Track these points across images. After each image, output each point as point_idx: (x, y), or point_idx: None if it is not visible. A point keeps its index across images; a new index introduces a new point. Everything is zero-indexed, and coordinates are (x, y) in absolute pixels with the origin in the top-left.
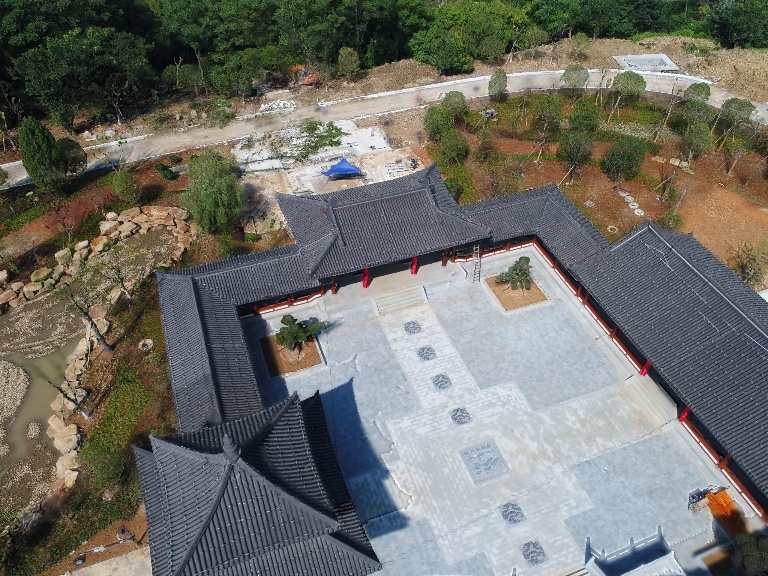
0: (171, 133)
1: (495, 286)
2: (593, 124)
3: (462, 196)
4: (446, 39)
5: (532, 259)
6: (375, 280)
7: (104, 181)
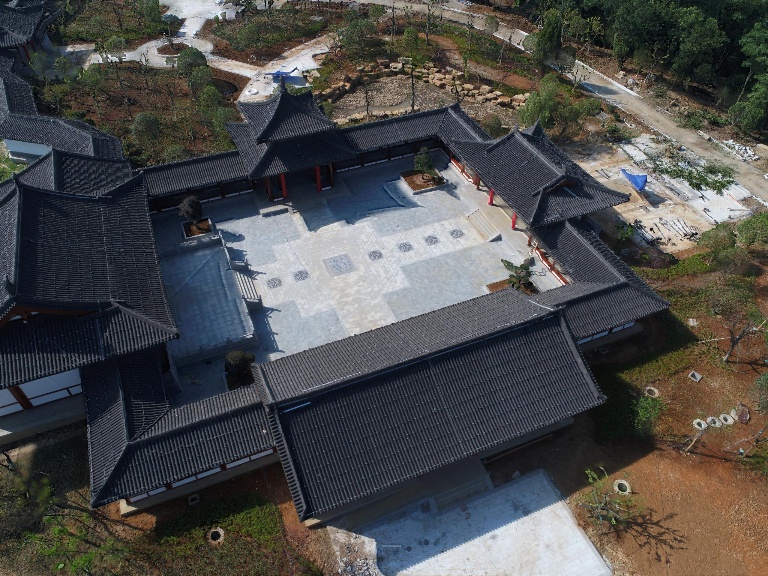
0: (651, 105)
1: (517, 281)
2: None
3: (653, 269)
4: None
5: None
6: (499, 208)
7: (565, 87)
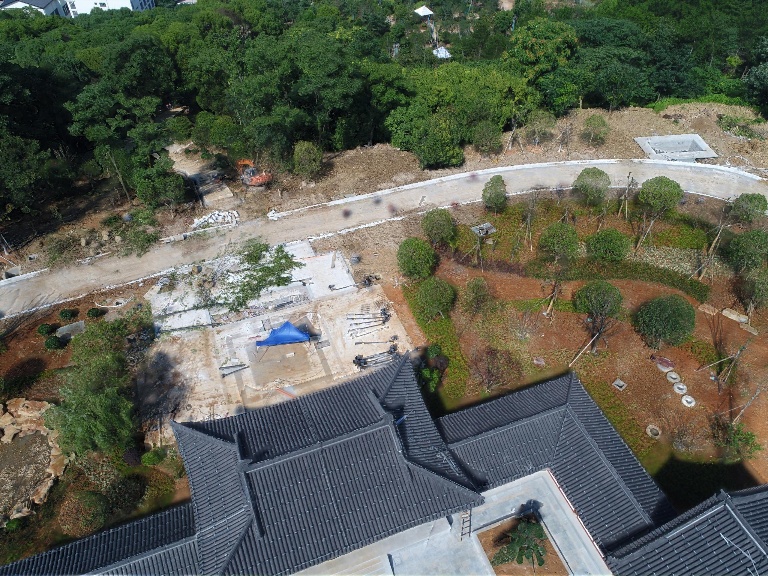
0: (72, 266)
1: (492, 549)
2: (619, 259)
3: (447, 372)
4: (429, 129)
5: (544, 490)
6: None
7: None
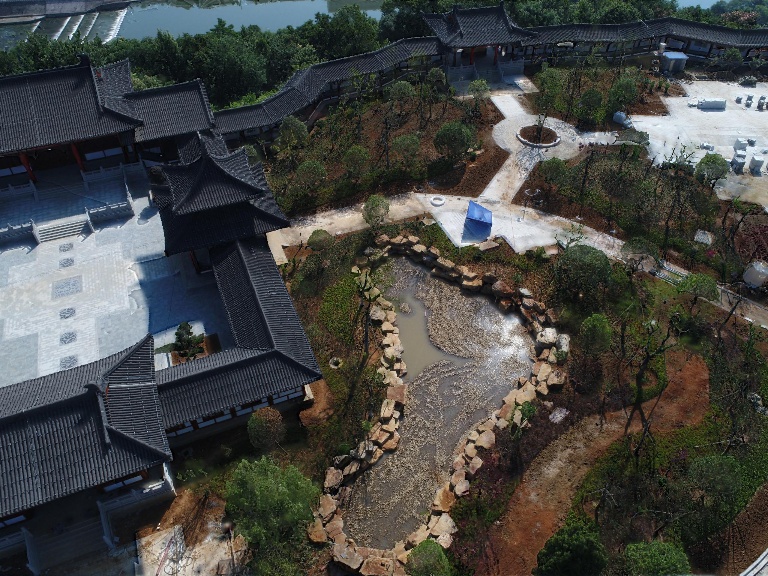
0: None
1: None
2: None
3: None
4: None
5: None
6: None
7: None
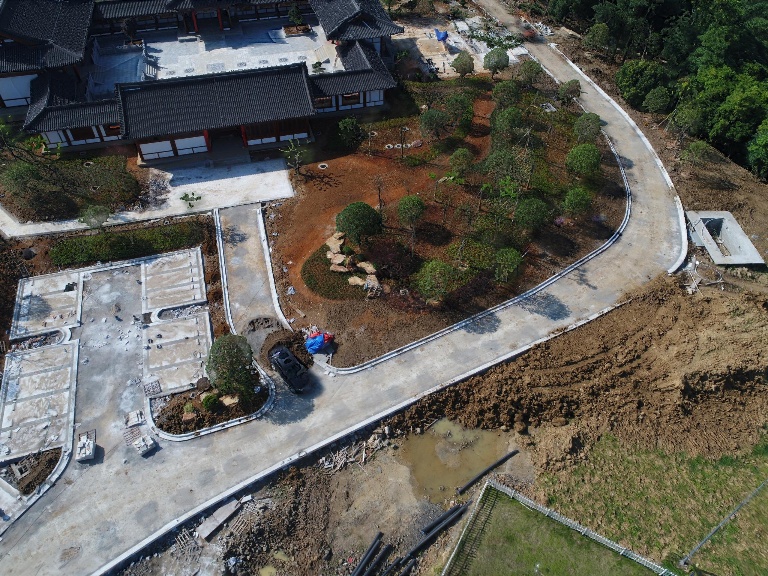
0: (498, 0)
1: None
2: (498, 125)
3: None
4: None
5: None
6: None
7: None
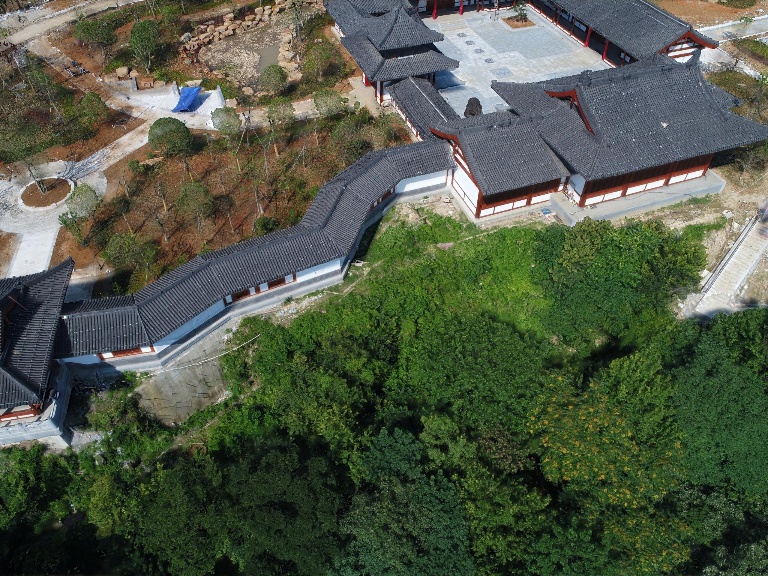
0: None
1: (507, 21)
2: None
3: None
4: None
5: (528, 13)
6: (439, 17)
7: None
